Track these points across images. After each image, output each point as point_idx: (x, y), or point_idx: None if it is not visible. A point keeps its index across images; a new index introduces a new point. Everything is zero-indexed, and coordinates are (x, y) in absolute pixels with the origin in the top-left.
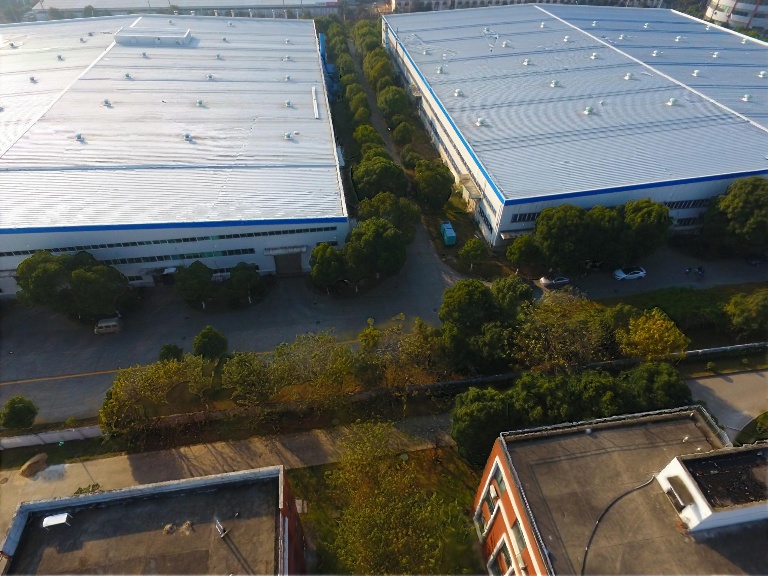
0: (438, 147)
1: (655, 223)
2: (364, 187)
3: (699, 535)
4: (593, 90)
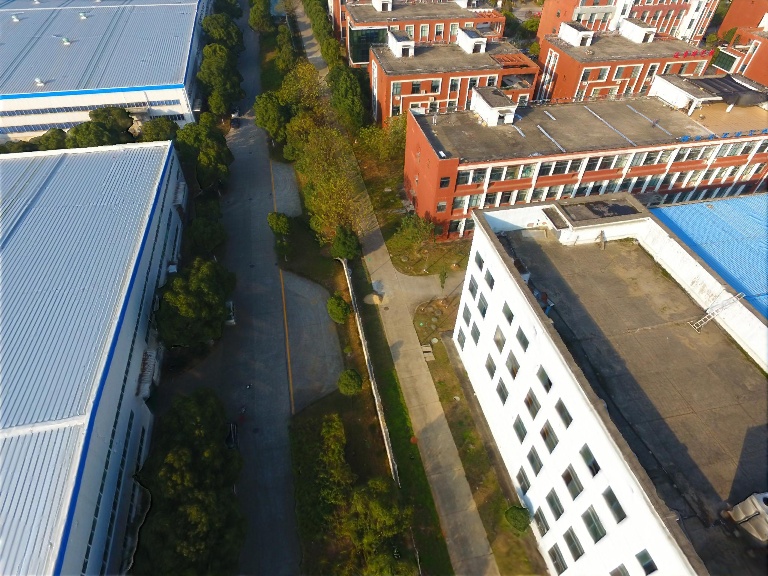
0: (7, 140)
1: None
2: None
3: None
4: (26, 34)
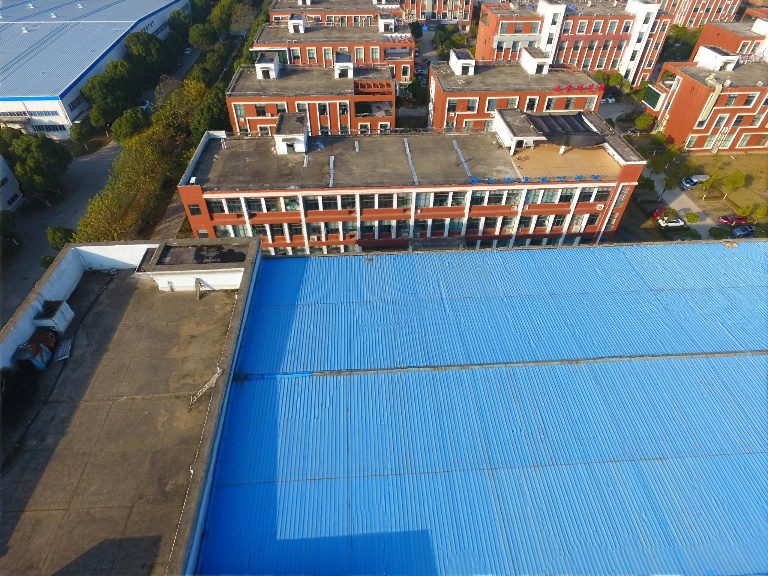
0: None
1: (130, 67)
2: None
3: (278, 78)
4: None
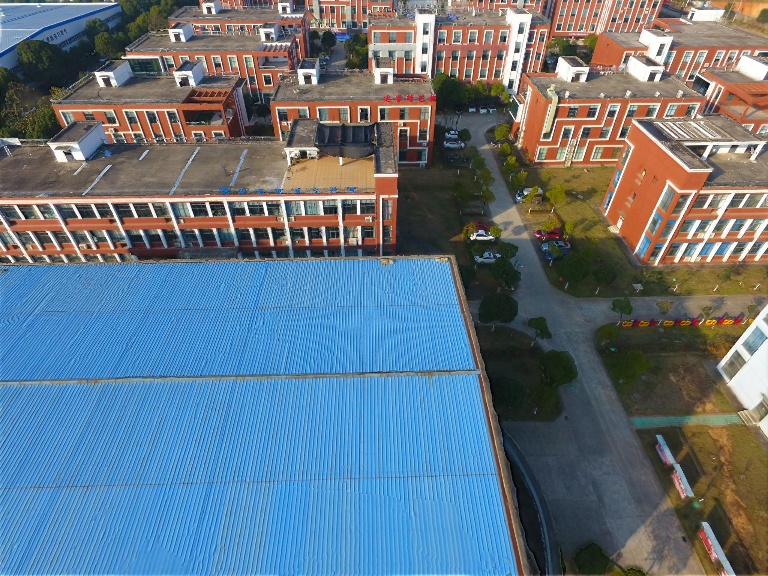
0: None
1: (9, 74)
2: None
3: (121, 86)
4: None
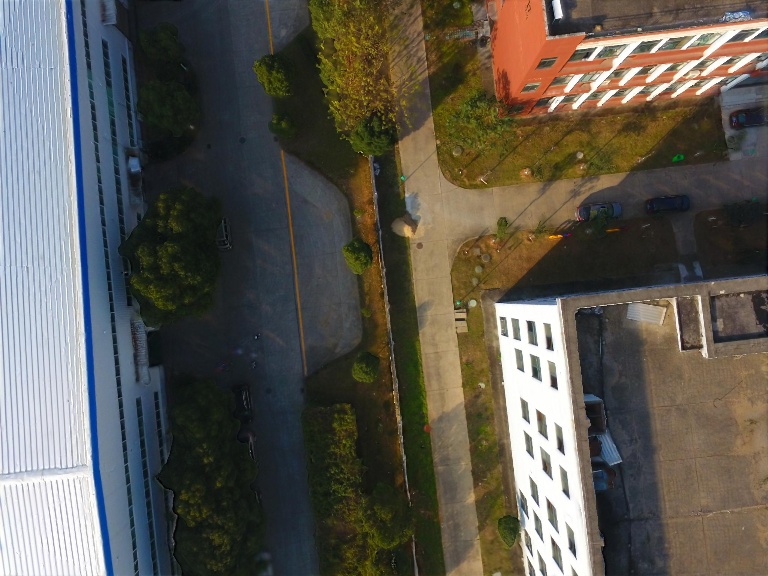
0: None
1: None
2: None
3: None
4: None
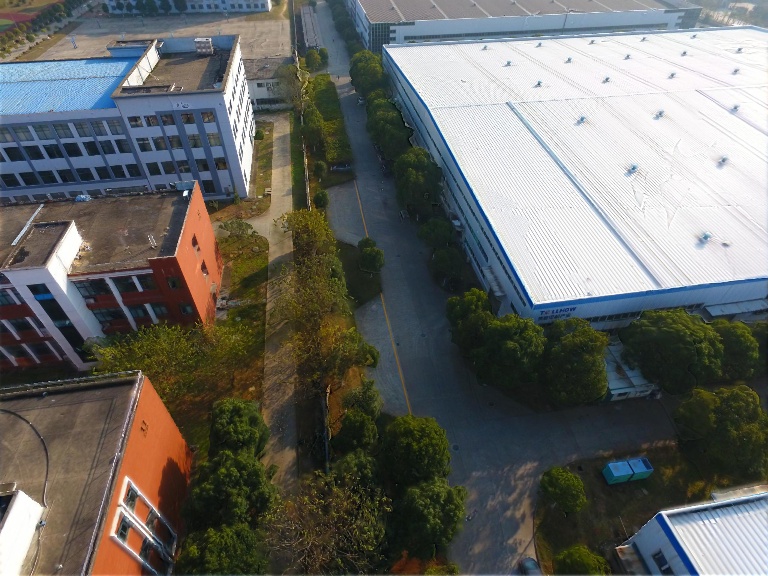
0: None
1: None
2: (635, 327)
3: None
4: None
